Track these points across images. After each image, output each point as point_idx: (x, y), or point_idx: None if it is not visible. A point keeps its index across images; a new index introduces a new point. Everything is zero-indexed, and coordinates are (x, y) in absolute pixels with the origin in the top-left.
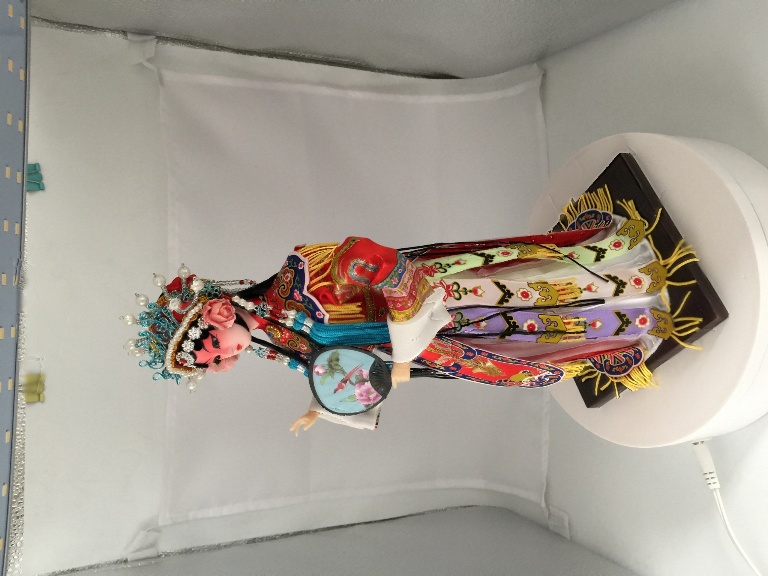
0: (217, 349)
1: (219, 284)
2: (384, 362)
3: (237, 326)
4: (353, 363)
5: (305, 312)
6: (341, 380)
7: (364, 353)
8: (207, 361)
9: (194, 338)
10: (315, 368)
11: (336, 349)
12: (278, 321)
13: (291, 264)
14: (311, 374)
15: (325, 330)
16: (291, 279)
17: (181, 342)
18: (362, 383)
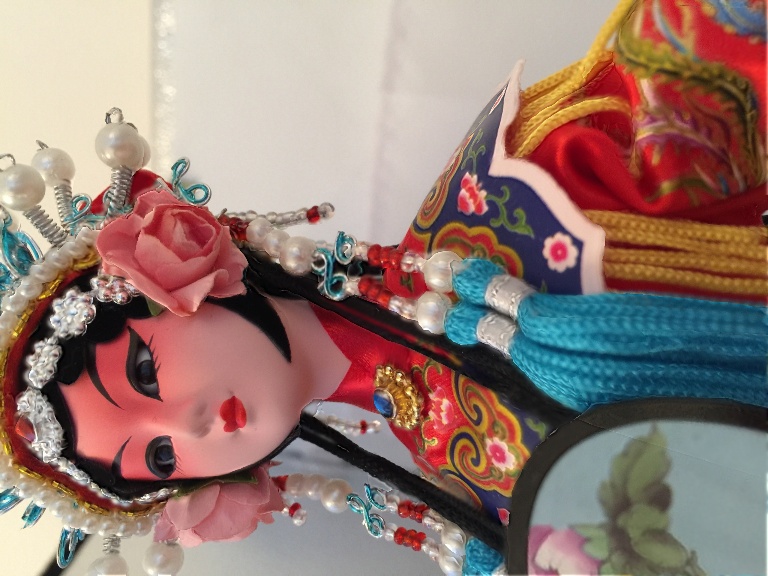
0: (150, 400)
1: (246, 223)
2: None
3: (244, 327)
4: (764, 531)
5: (499, 261)
6: None
7: None
8: (120, 454)
9: (68, 332)
10: (538, 545)
11: (648, 421)
12: (396, 321)
13: (471, 130)
14: None
15: (584, 315)
16: (458, 156)
17: (29, 346)
18: None
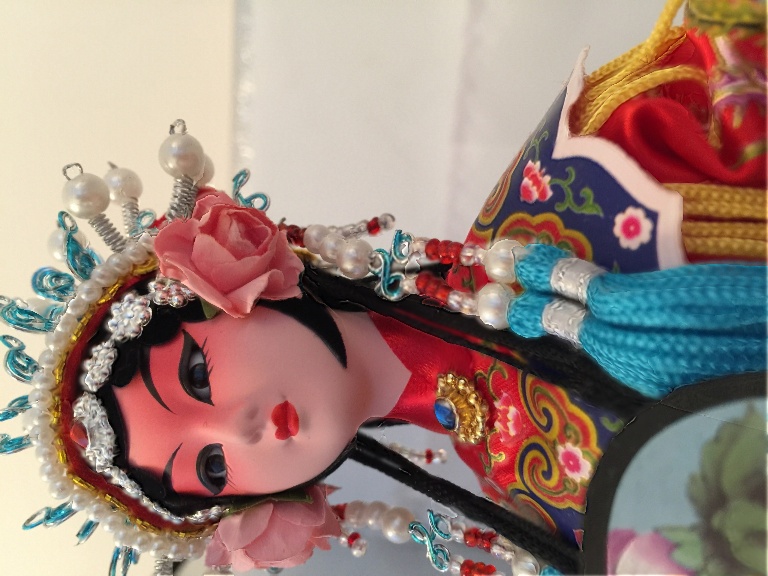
0: (202, 405)
1: None
2: None
3: (298, 331)
4: None
5: (565, 246)
6: None
7: None
8: (171, 462)
9: (124, 335)
10: (619, 554)
11: (743, 401)
12: (457, 320)
13: None
14: None
15: (662, 288)
16: None
17: (88, 350)
18: None
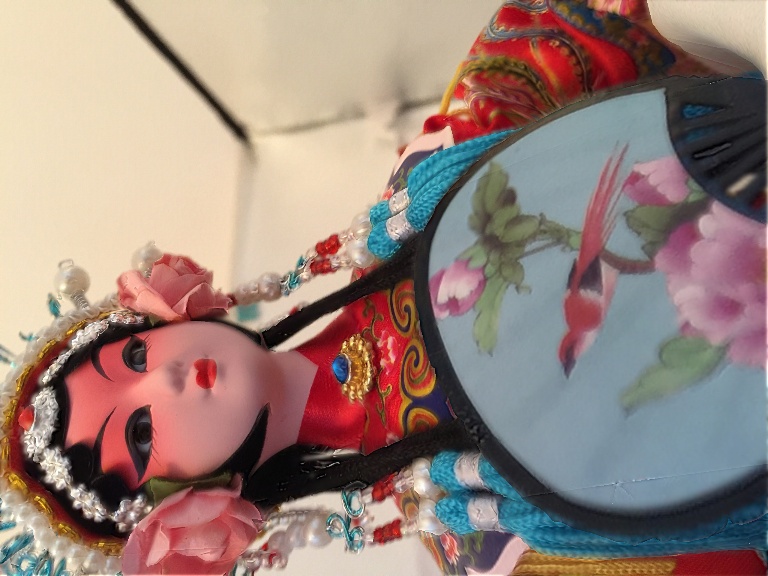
0: (138, 375)
1: None
2: (720, 77)
3: None
4: (580, 172)
5: None
6: (567, 280)
7: (600, 103)
8: (103, 430)
9: (83, 343)
10: (437, 291)
11: (486, 164)
12: None
13: None
14: (430, 329)
15: None
16: None
17: None
18: (683, 236)
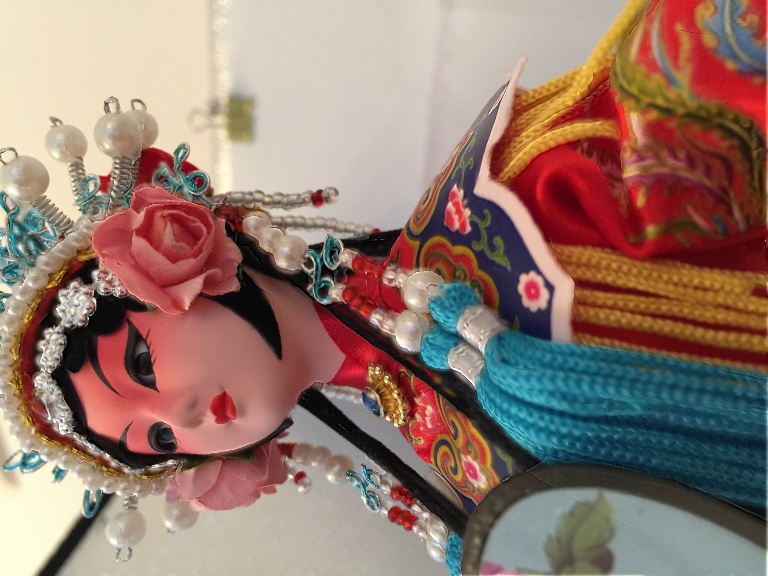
0: (148, 390)
1: (253, 203)
2: None
3: (237, 323)
4: None
5: (477, 286)
6: None
7: None
8: (125, 434)
9: (72, 322)
10: None
11: (594, 487)
12: (381, 330)
13: (475, 123)
14: None
15: (545, 367)
16: (453, 159)
17: (40, 331)
18: None
